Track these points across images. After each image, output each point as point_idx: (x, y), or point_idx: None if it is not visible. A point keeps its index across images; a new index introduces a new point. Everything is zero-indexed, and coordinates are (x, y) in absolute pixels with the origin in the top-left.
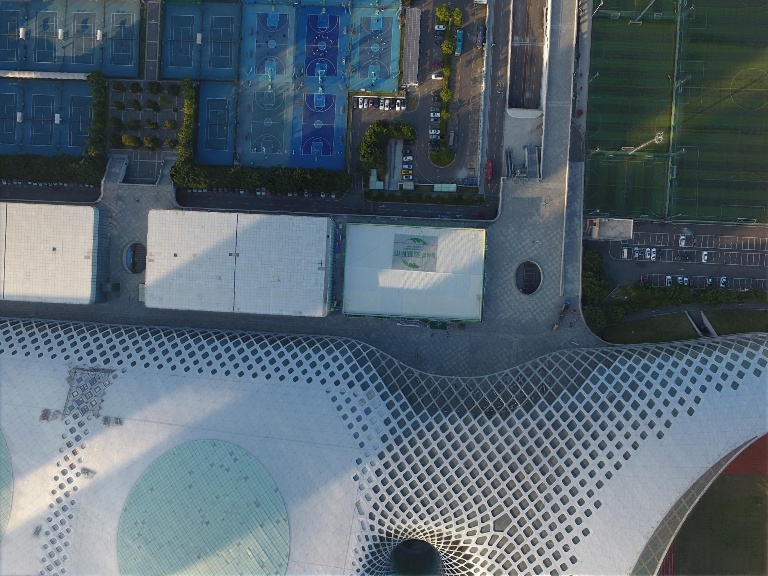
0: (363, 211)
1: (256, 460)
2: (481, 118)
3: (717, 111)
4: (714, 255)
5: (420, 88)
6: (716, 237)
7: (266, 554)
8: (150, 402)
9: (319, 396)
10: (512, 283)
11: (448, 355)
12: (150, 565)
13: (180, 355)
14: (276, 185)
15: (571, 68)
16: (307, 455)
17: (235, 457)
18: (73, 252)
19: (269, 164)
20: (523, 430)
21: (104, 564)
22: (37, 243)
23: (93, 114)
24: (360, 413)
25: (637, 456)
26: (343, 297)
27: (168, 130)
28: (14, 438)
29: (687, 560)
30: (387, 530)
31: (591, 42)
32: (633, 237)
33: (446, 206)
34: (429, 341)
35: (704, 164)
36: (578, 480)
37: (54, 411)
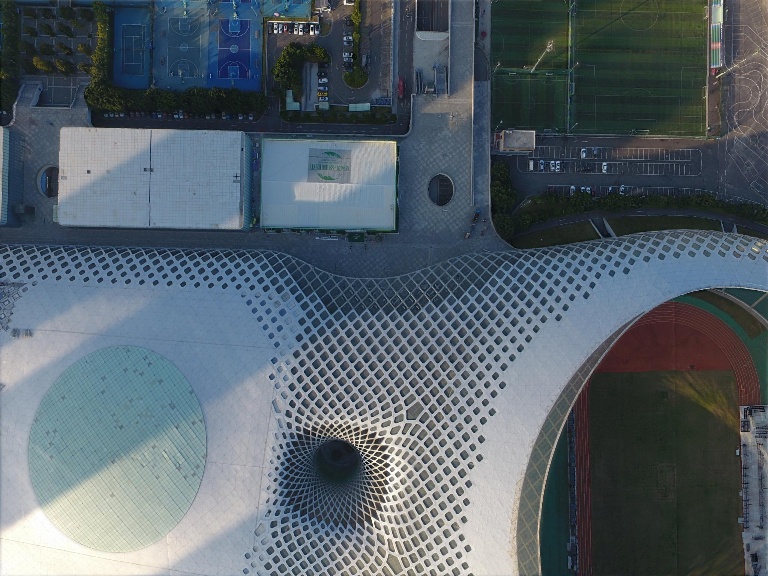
0: None
1: (171, 363)
2: (392, 41)
3: (609, 32)
4: (613, 166)
5: (333, 14)
6: (614, 149)
7: (182, 456)
8: (62, 313)
9: (234, 300)
10: (425, 195)
11: (367, 267)
12: (63, 474)
13: (93, 268)
14: (191, 105)
15: None
16: (222, 357)
17: (149, 361)
18: None
19: (185, 87)
20: (433, 323)
21: (15, 478)
22: None
23: (3, 39)
24: (275, 314)
25: (538, 338)
26: (260, 211)
27: (83, 56)
28: None
29: (602, 456)
30: (304, 427)
31: None
32: (538, 151)
33: (361, 125)
34: (348, 254)
35: (600, 81)
36: (484, 365)
37: None
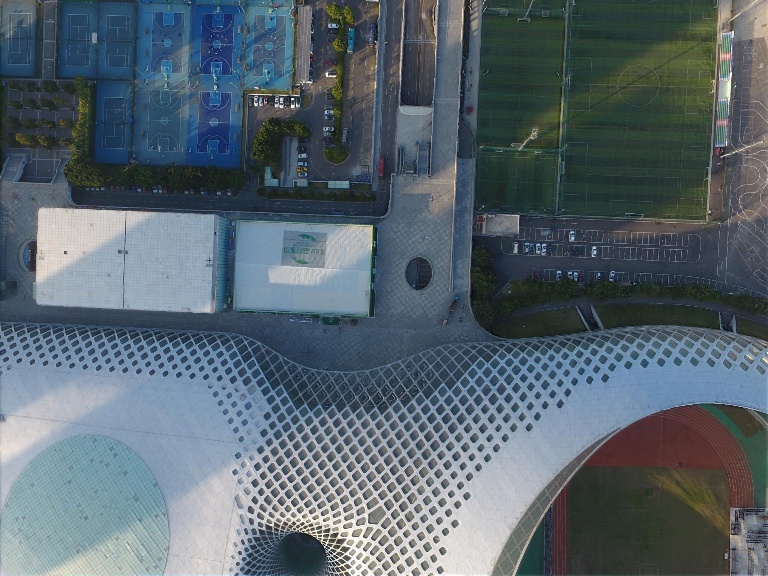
0: (258, 208)
1: (136, 455)
2: (374, 115)
3: (605, 107)
4: (603, 250)
5: (314, 86)
6: (605, 232)
7: (145, 548)
8: (33, 398)
9: (201, 391)
10: (403, 279)
11: (341, 350)
12: (31, 560)
13: (66, 352)
14: (168, 183)
15: (458, 65)
16: (187, 450)
17: (115, 452)
18: None
19: (164, 162)
20: (399, 424)
21: None
22: None
23: None
24: (241, 408)
25: (506, 448)
26: (234, 293)
27: (66, 129)
28: None
29: (580, 552)
30: (266, 523)
31: (481, 39)
32: (524, 232)
33: (340, 203)
34: (322, 337)
35: (593, 160)
36: (449, 472)
37: None
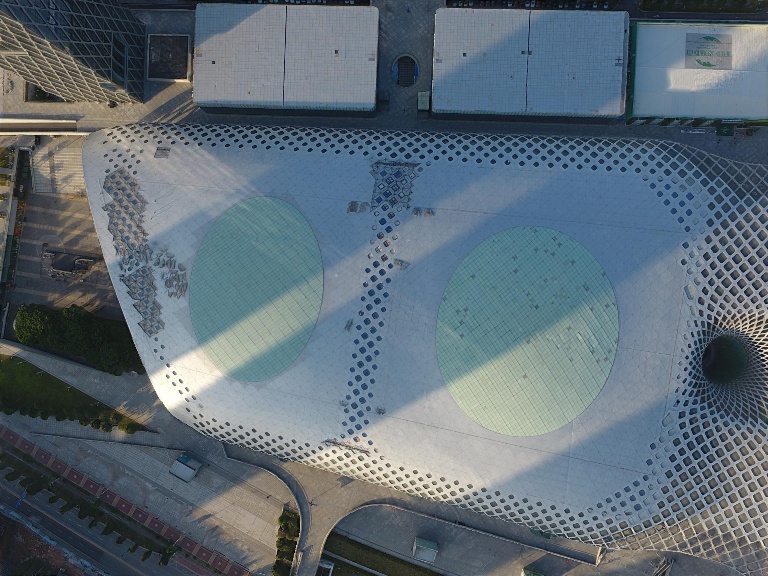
0: None
1: (580, 245)
2: None
3: None
4: None
5: None
6: None
7: (596, 339)
8: (461, 192)
9: (637, 183)
10: None
11: None
12: (474, 353)
13: (482, 150)
14: None
15: None
16: (631, 240)
17: (559, 242)
18: (357, 54)
19: None
20: None
21: (420, 357)
22: (319, 46)
23: None
24: (682, 198)
25: None
26: (633, 99)
27: None
28: (323, 230)
29: None
30: (715, 316)
31: None
32: None
33: (724, 14)
34: (715, 148)
35: None
36: None
37: (362, 203)
